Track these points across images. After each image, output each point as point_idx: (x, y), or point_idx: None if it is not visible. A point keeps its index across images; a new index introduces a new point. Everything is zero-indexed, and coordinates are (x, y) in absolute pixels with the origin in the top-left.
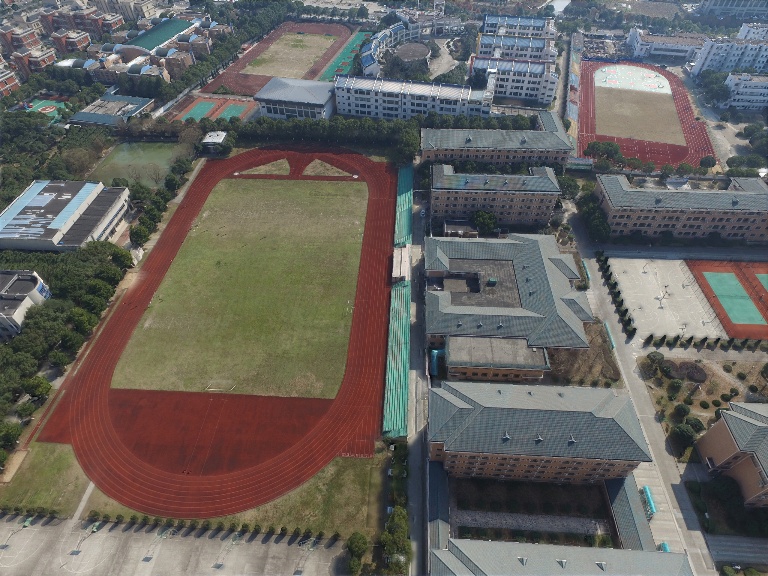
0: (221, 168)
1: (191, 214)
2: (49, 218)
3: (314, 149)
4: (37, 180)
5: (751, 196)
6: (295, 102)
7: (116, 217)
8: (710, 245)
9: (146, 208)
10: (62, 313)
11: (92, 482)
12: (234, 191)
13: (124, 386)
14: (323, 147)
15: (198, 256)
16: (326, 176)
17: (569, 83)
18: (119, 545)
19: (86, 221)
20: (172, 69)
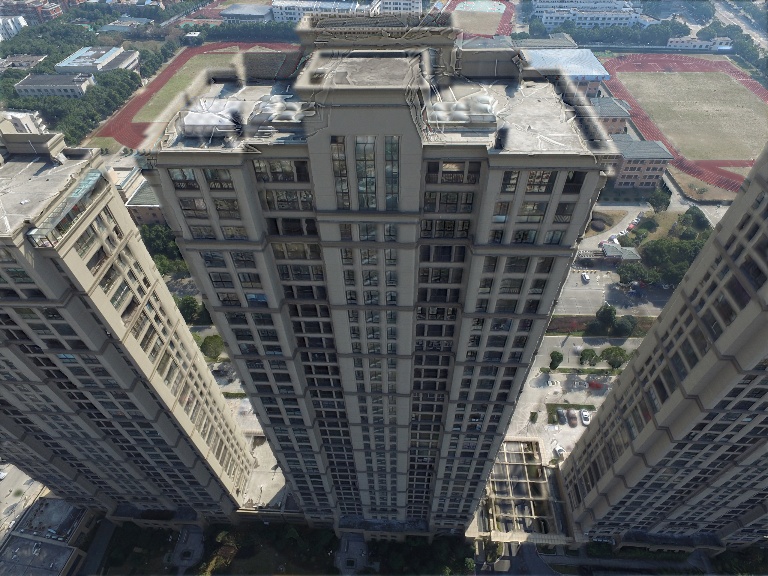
0: (196, 50)
1: (176, 68)
2: (94, 59)
3: (256, 41)
4: (84, 47)
5: None
6: (246, 15)
7: (132, 64)
8: None
9: (149, 59)
10: (105, 92)
11: (124, 145)
12: (203, 59)
13: (138, 122)
14: (262, 40)
15: (179, 82)
16: (261, 52)
17: (433, 6)
18: (138, 159)
19: (115, 62)
20: (166, 5)
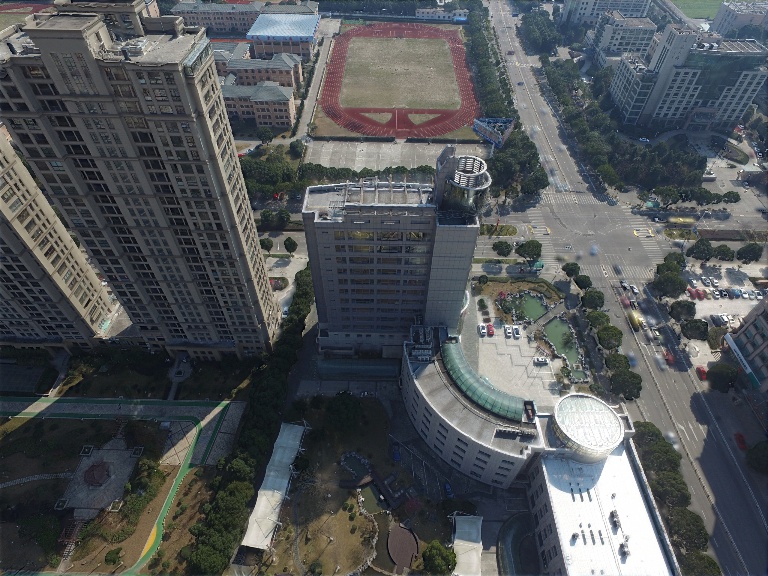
0: None
1: None
2: None
3: None
4: None
5: (242, 5)
6: None
7: None
8: (230, 34)
9: None
10: None
11: None
12: None
13: None
14: None
15: None
16: None
17: None
18: None
19: None
20: None
